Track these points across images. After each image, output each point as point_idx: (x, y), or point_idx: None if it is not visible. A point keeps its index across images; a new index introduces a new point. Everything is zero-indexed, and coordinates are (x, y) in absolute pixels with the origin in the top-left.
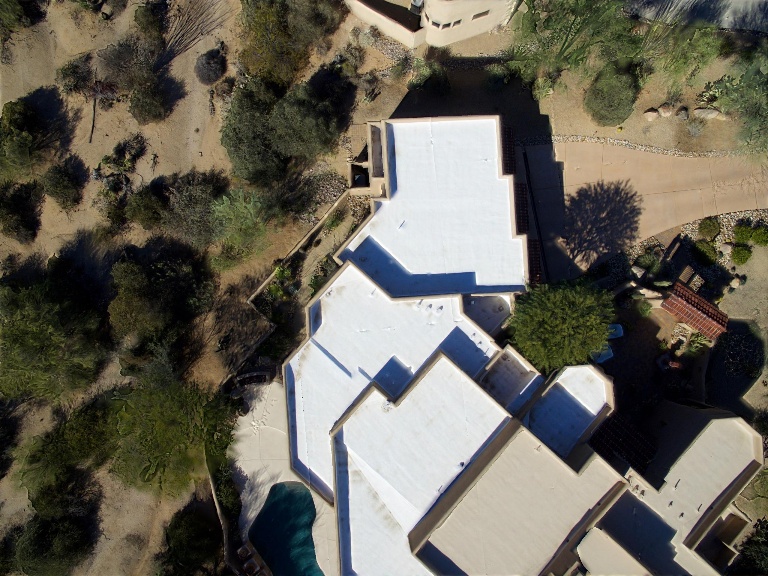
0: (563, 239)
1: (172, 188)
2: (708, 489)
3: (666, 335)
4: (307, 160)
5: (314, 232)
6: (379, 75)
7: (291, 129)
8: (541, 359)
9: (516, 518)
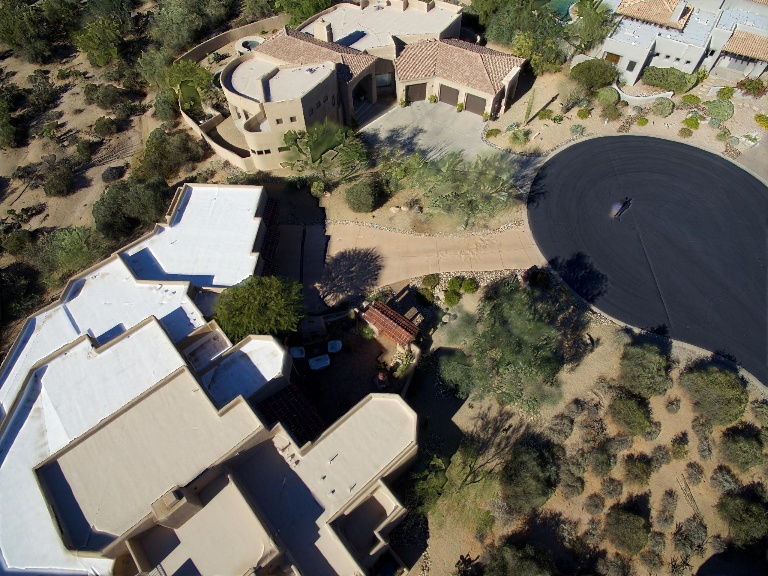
0: (318, 284)
1: (47, 233)
2: (365, 468)
3: (387, 359)
4: (151, 226)
5: None
6: None
7: (138, 198)
8: (227, 323)
9: (151, 454)
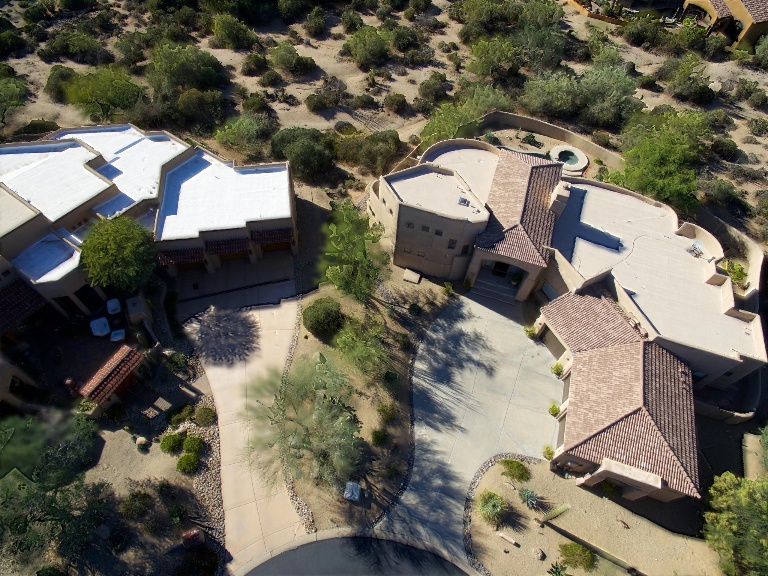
0: (214, 309)
1: None
2: None
3: None
4: None
5: None
6: None
7: None
8: None
9: None
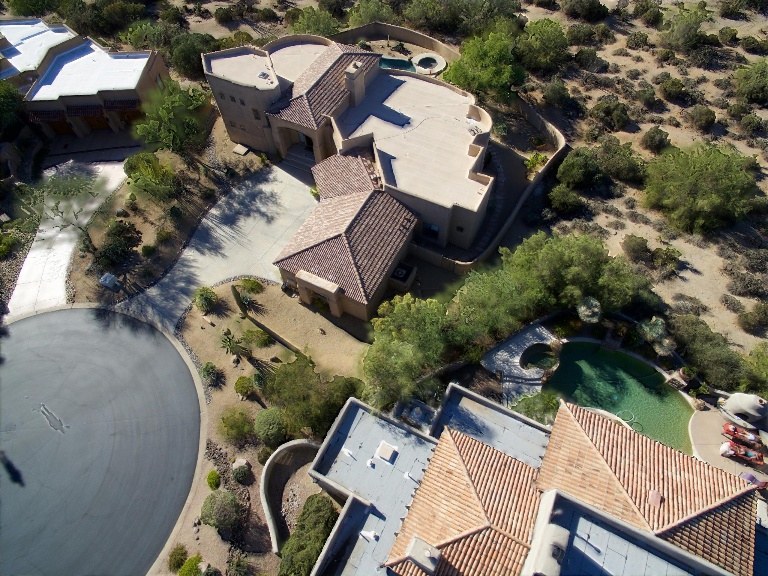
0: None
1: None
2: None
3: None
4: None
5: None
6: None
7: None
8: None
9: None
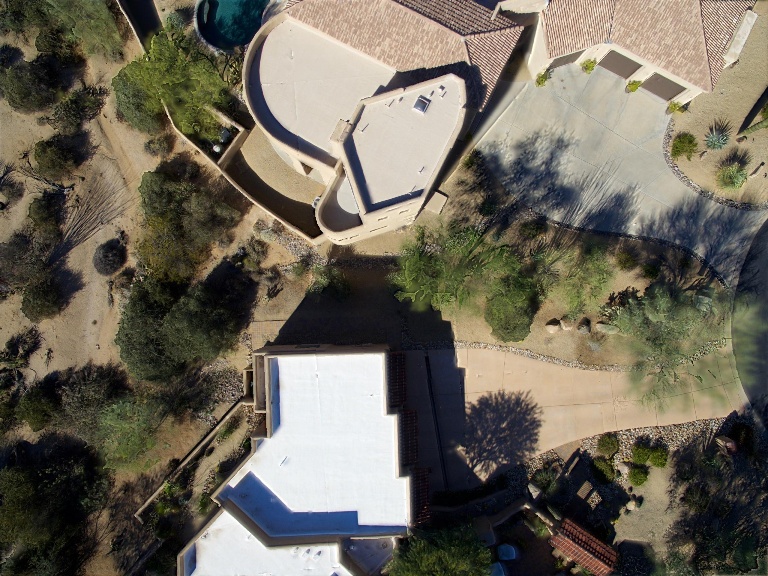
0: (463, 447)
1: (66, 385)
2: None
3: None
4: None
5: (205, 443)
6: (282, 270)
7: (183, 339)
8: None
9: None
